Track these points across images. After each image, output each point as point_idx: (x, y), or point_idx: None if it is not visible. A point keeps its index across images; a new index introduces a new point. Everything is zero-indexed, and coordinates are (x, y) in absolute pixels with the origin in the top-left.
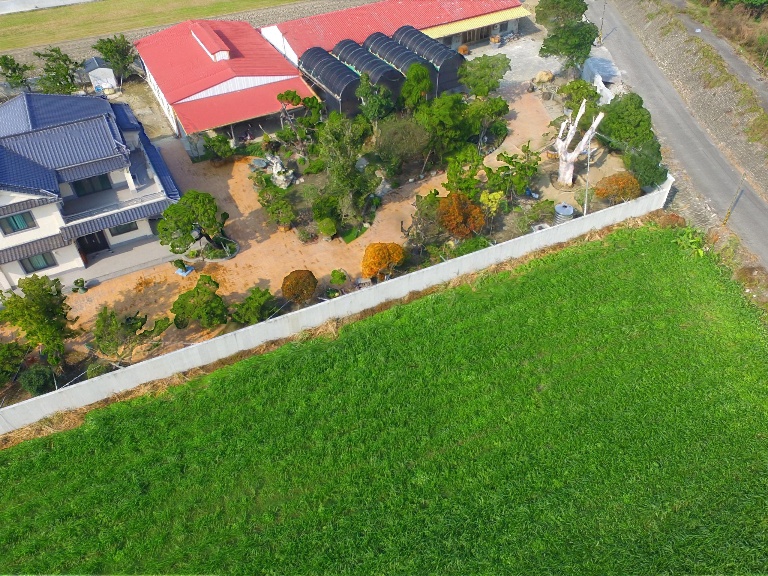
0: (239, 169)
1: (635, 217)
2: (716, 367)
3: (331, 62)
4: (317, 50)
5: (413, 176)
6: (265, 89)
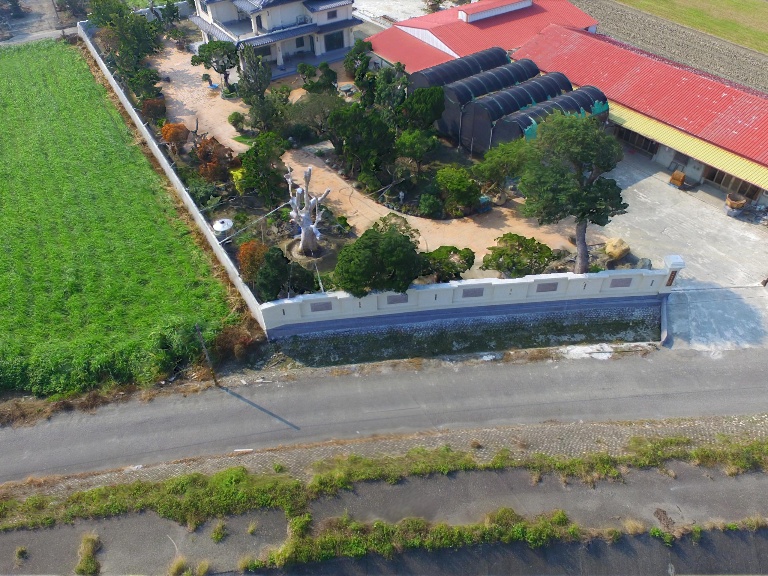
0: (345, 84)
1: (244, 304)
2: (4, 320)
3: (462, 58)
4: (493, 50)
5: (338, 162)
6: (435, 53)
